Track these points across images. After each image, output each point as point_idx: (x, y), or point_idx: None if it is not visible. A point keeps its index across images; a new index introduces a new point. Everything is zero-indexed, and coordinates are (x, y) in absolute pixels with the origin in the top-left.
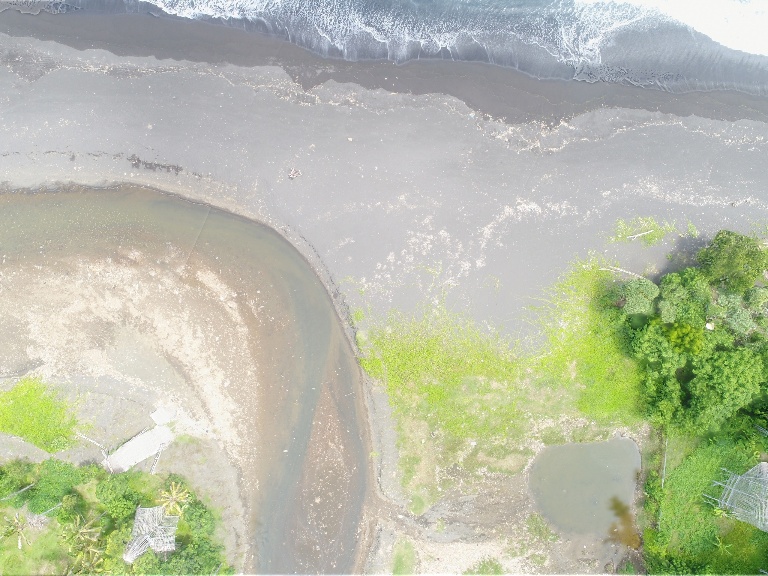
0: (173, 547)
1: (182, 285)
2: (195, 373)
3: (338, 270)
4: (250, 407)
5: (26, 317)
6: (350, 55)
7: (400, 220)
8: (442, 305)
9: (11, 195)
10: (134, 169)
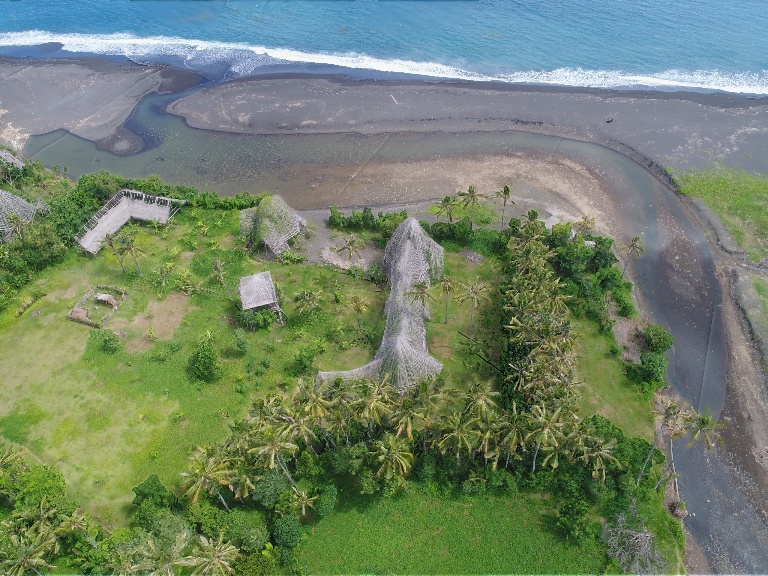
0: (594, 243)
1: (551, 164)
2: (569, 197)
3: (649, 153)
4: (610, 213)
5: (454, 176)
6: (623, 92)
7: (678, 135)
8: (721, 165)
9: (443, 135)
10: (515, 124)
